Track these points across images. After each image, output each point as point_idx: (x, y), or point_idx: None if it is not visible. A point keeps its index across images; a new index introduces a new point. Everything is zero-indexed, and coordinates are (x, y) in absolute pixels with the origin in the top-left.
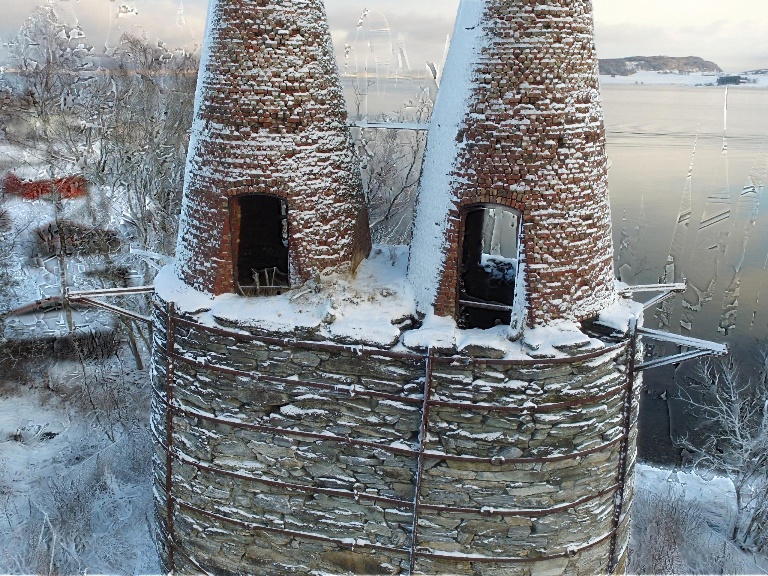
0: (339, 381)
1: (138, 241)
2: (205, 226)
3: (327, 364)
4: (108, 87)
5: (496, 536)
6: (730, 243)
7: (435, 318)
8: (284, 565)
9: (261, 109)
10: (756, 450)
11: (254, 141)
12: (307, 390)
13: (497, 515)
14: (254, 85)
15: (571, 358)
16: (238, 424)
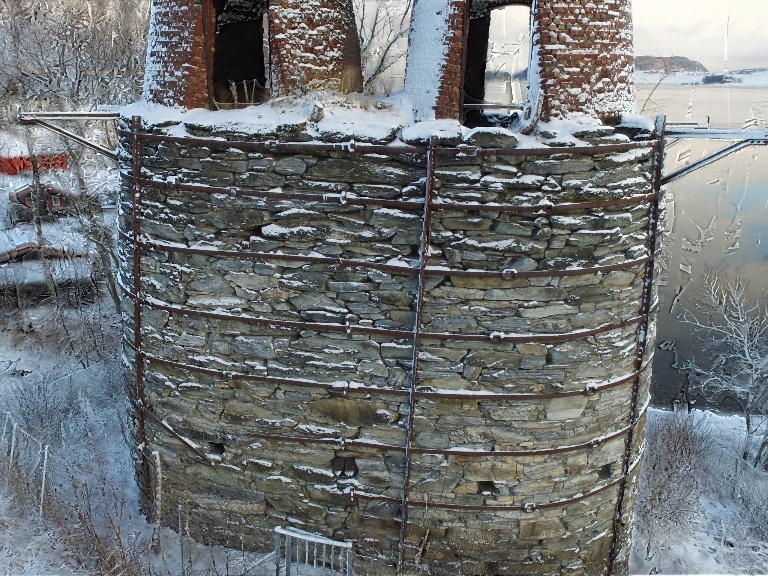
0: (328, 190)
1: (116, 173)
2: (175, 29)
3: (314, 170)
4: (82, 5)
5: (507, 368)
6: (731, 180)
7: None
8: (267, 420)
9: None
10: (766, 370)
11: None
12: (292, 204)
13: (508, 342)
14: None
15: (593, 147)
16: (214, 252)
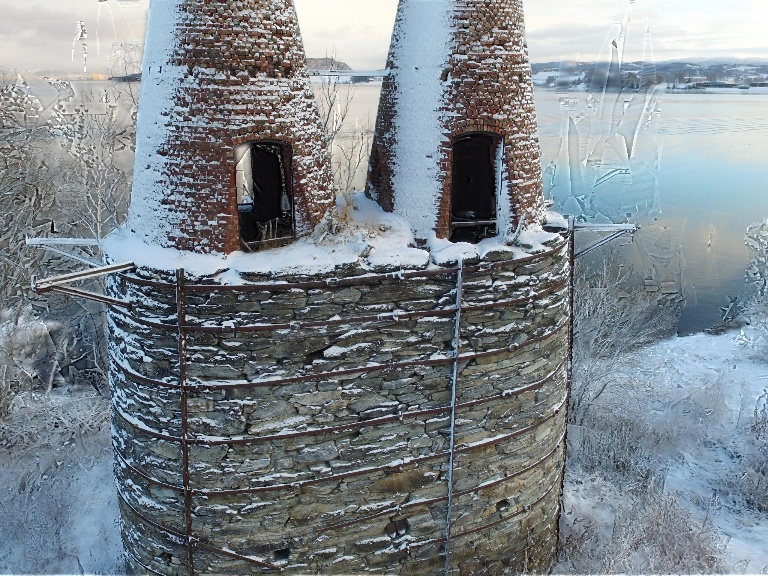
0: (380, 310)
1: None
2: (204, 181)
3: (369, 296)
4: None
5: (513, 414)
6: None
7: (439, 240)
8: (333, 513)
9: (257, 52)
10: None
11: (254, 86)
12: (350, 327)
13: (513, 396)
14: (247, 27)
15: (553, 250)
16: (279, 381)
